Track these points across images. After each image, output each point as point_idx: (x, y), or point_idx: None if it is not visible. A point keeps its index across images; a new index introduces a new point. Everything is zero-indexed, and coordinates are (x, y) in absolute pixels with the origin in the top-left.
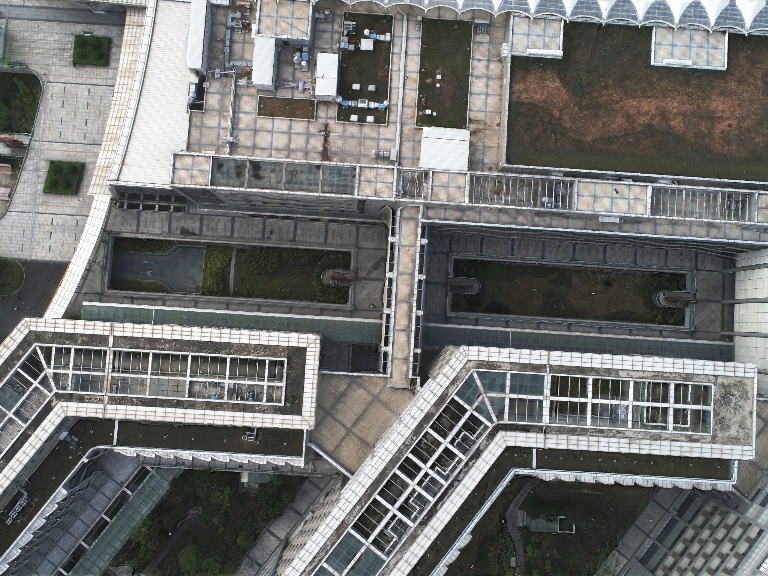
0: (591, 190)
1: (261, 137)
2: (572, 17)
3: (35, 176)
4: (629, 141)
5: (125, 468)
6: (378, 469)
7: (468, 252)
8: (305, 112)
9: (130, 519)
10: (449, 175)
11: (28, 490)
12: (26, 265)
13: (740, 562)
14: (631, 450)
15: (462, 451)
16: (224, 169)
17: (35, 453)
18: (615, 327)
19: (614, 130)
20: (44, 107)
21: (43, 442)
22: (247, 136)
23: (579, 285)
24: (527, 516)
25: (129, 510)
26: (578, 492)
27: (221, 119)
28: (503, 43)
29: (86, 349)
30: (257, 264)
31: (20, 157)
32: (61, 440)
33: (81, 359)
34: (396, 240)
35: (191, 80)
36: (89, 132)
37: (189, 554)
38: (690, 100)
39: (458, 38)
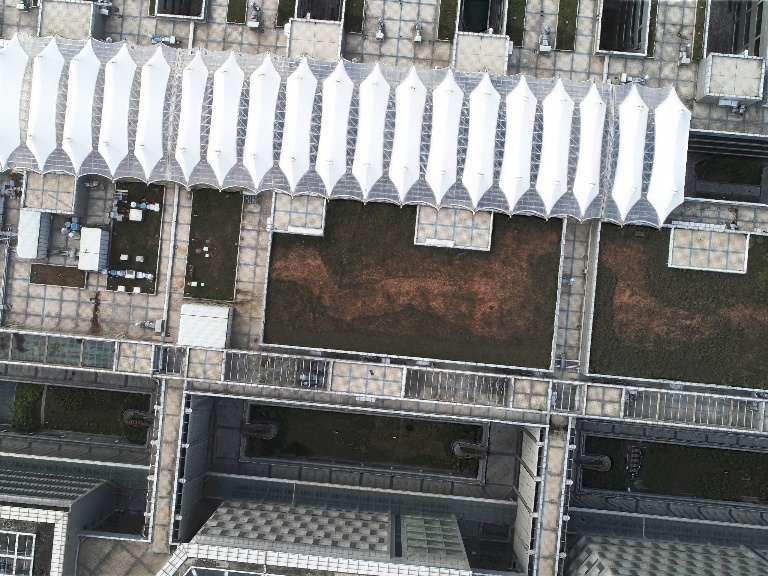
0: (347, 370)
1: (33, 304)
2: (333, 196)
3: None
4: (388, 321)
5: None
6: None
7: None
8: (76, 280)
9: None
10: (206, 352)
11: None
12: None
13: None
14: None
15: None
16: None
17: None
18: (407, 477)
19: (374, 310)
20: None
21: None
22: (20, 302)
23: (381, 428)
24: None
25: None
26: None
27: None
28: (268, 218)
29: None
30: (62, 402)
31: None
32: None
33: None
34: (160, 409)
35: None
36: None
37: None
38: (452, 281)
39: (228, 208)
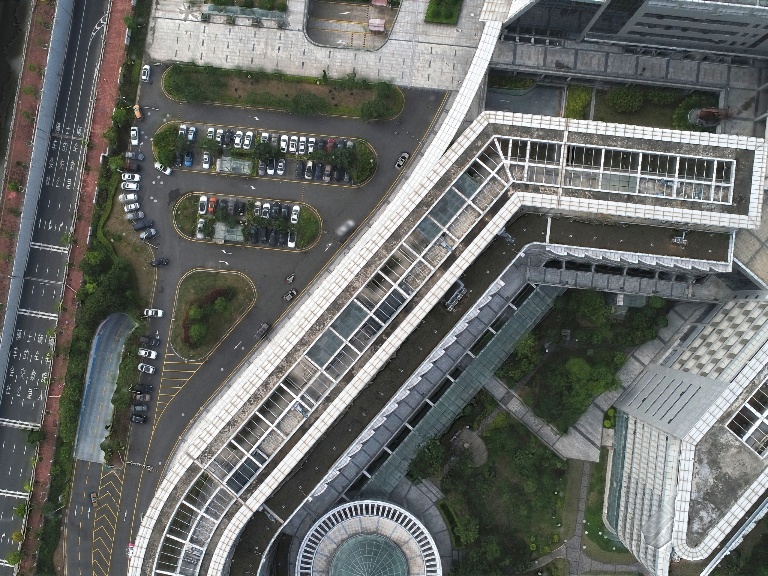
0: None
1: None
2: None
3: (416, 6)
4: None
5: (511, 284)
6: None
7: None
8: None
9: (515, 332)
10: None
11: (464, 282)
12: (406, 92)
13: None
14: None
15: None
16: None
17: (492, 239)
18: None
19: None
20: None
21: (500, 229)
22: None
23: None
24: None
25: (514, 324)
26: None
27: None
28: None
29: (542, 143)
30: (625, 101)
31: None
32: (499, 235)
33: (536, 152)
34: None
35: None
36: None
37: (581, 364)
38: None
39: None
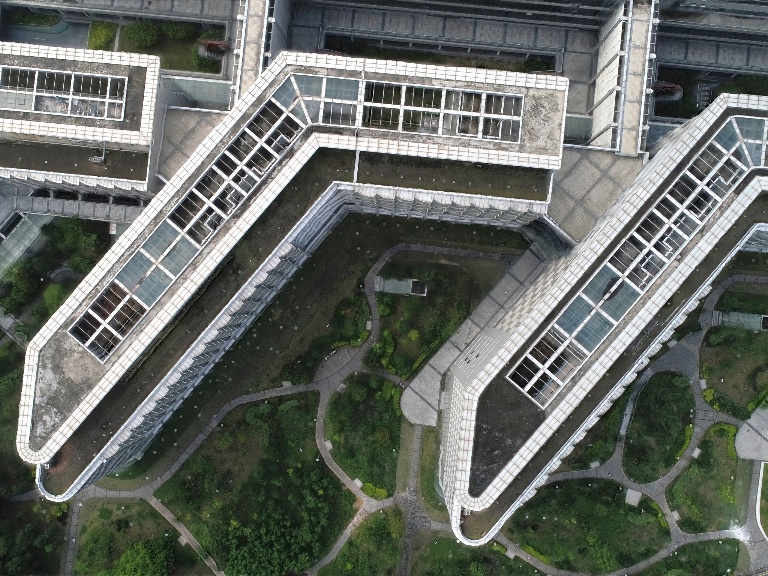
0: None
1: None
2: None
3: None
4: None
5: None
6: (196, 164)
7: (339, 26)
8: None
9: (3, 261)
10: None
11: None
12: None
13: (553, 283)
14: (439, 155)
15: (276, 150)
16: None
17: None
18: None
19: None
20: None
21: None
22: None
23: None
24: (383, 281)
25: (2, 252)
26: (435, 262)
27: None
28: None
29: None
30: (137, 35)
31: None
32: None
33: None
34: None
35: None
36: None
37: (52, 289)
38: None
39: None
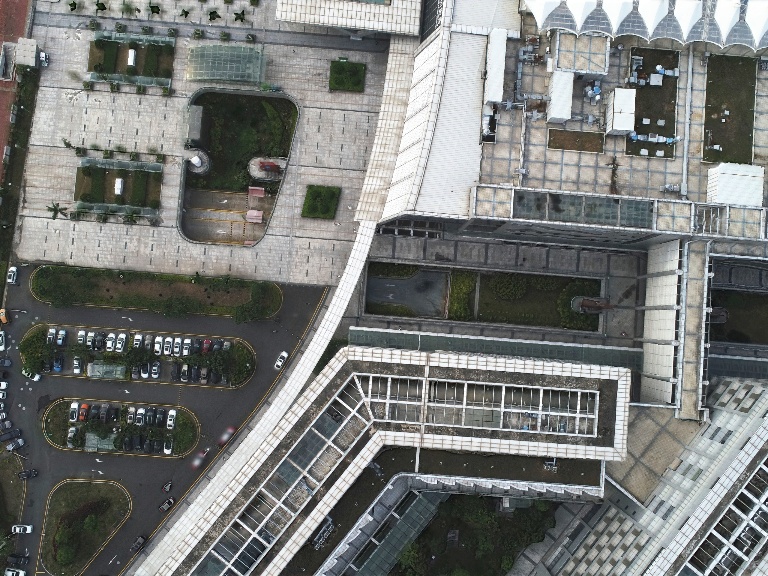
0: None
1: (551, 169)
2: None
3: (292, 200)
4: None
5: (393, 492)
6: (714, 504)
7: (718, 282)
8: (594, 145)
9: (398, 542)
10: (744, 211)
11: (332, 516)
12: (284, 288)
13: None
14: None
15: None
16: (525, 201)
17: (354, 481)
18: None
19: None
20: (300, 132)
21: (362, 470)
22: (537, 168)
23: None
24: None
25: (397, 533)
26: None
27: (512, 151)
28: None
29: (403, 379)
30: (507, 290)
31: (272, 180)
32: (366, 467)
33: (397, 388)
34: (684, 273)
35: (486, 112)
36: (345, 157)
37: None
38: None
39: (743, 74)
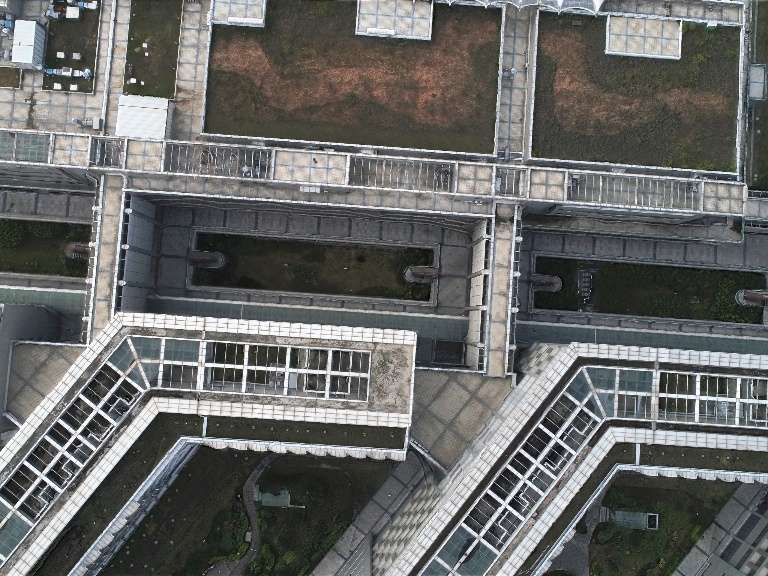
0: (289, 159)
1: None
2: None
3: None
4: (331, 111)
5: None
6: (27, 435)
7: (210, 226)
8: (10, 80)
9: None
10: (145, 144)
11: None
12: None
13: (414, 532)
14: (285, 417)
15: (113, 417)
16: None
17: None
18: (358, 302)
19: (316, 100)
20: None
21: None
22: None
23: (332, 260)
24: None
25: None
26: (316, 467)
27: None
28: (208, 12)
29: None
30: (0, 237)
31: None
32: None
33: None
34: (99, 209)
35: None
36: None
37: None
38: (394, 70)
39: (168, 7)
